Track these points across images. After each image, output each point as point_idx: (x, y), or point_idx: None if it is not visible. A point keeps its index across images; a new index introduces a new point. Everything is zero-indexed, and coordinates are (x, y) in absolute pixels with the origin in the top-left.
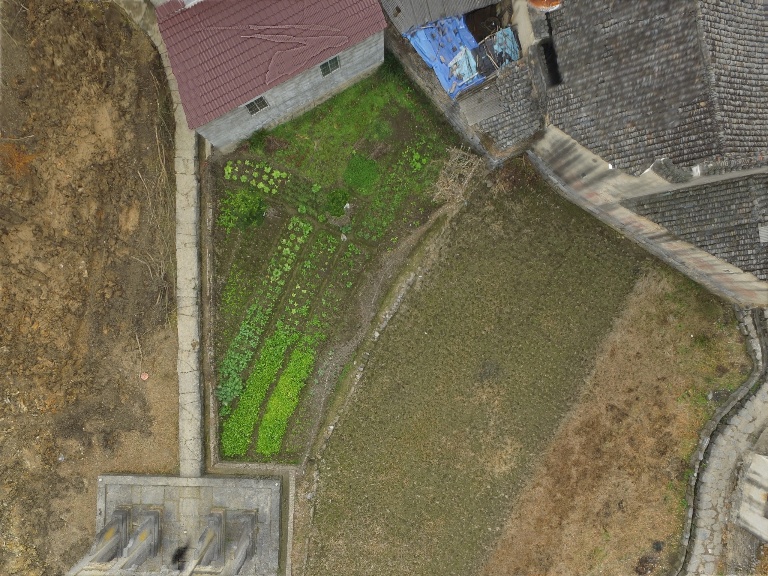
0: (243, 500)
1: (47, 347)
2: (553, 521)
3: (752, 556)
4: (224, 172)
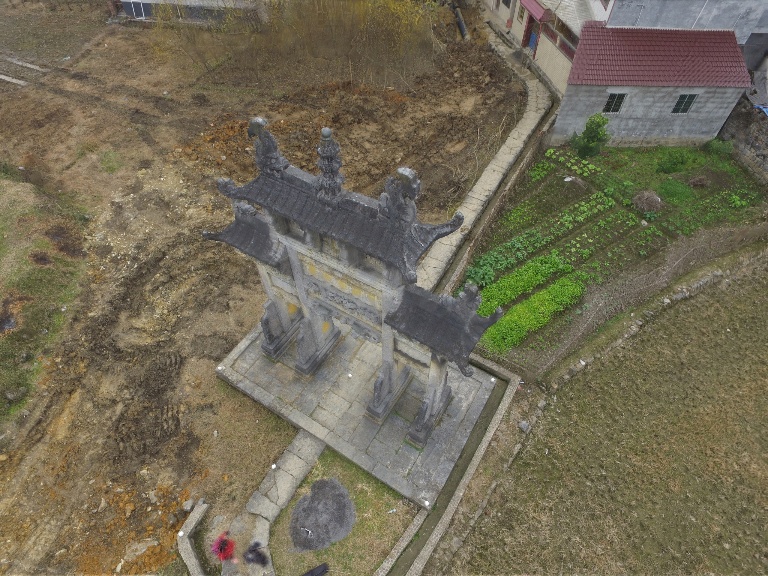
0: None
1: None
2: None
3: None
4: (546, 152)
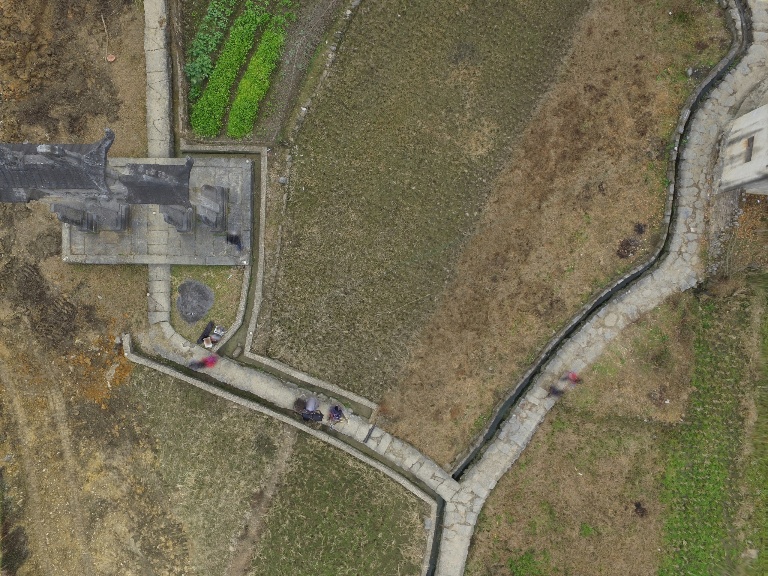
0: (213, 180)
1: (10, 31)
2: (532, 204)
3: (734, 209)
4: None
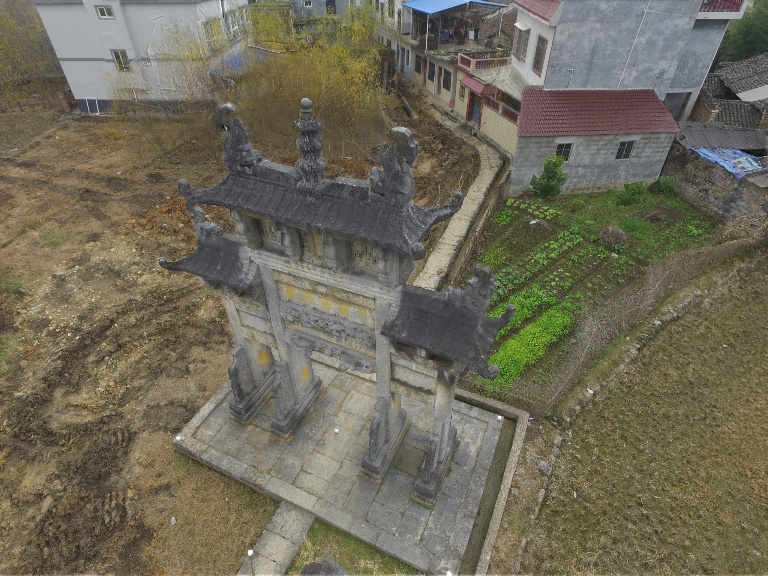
0: None
1: None
2: None
3: None
4: (506, 202)
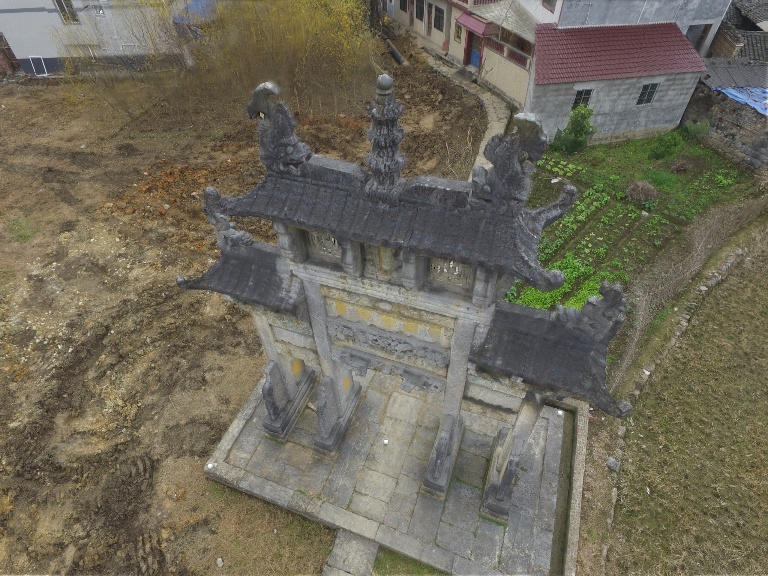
0: (496, 423)
1: None
2: None
3: None
4: None
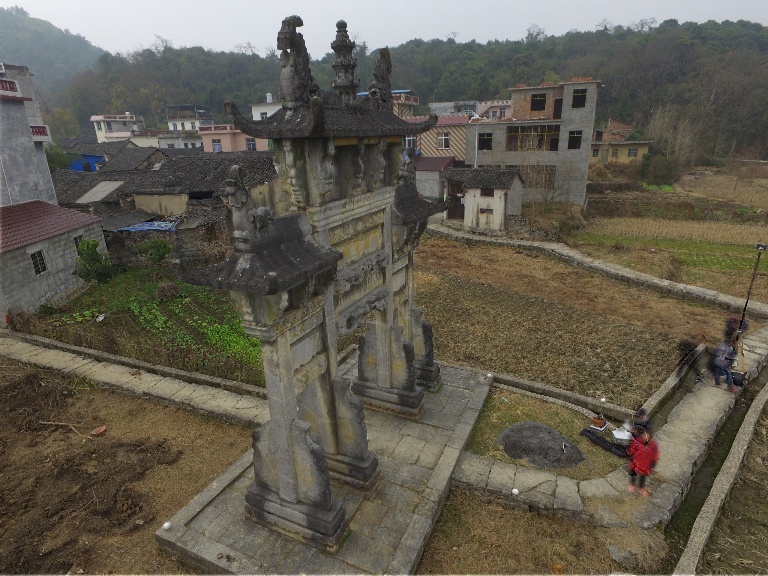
0: None
1: None
2: None
3: (518, 219)
4: None
